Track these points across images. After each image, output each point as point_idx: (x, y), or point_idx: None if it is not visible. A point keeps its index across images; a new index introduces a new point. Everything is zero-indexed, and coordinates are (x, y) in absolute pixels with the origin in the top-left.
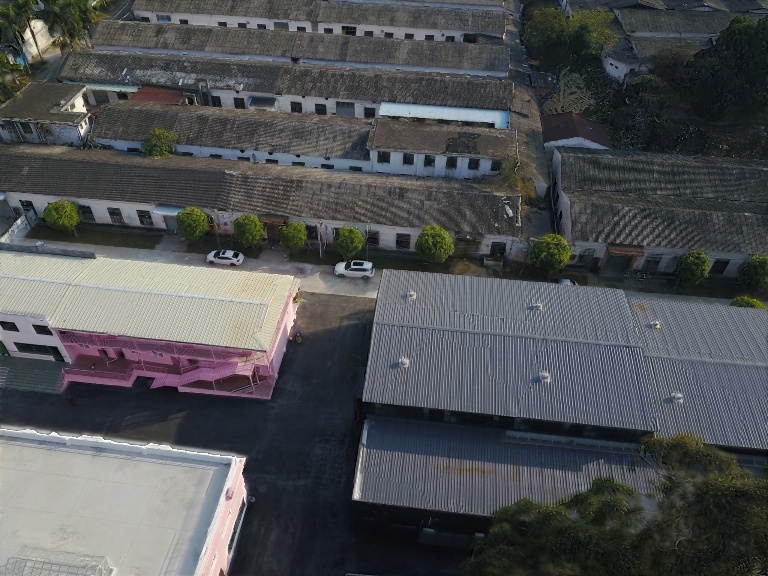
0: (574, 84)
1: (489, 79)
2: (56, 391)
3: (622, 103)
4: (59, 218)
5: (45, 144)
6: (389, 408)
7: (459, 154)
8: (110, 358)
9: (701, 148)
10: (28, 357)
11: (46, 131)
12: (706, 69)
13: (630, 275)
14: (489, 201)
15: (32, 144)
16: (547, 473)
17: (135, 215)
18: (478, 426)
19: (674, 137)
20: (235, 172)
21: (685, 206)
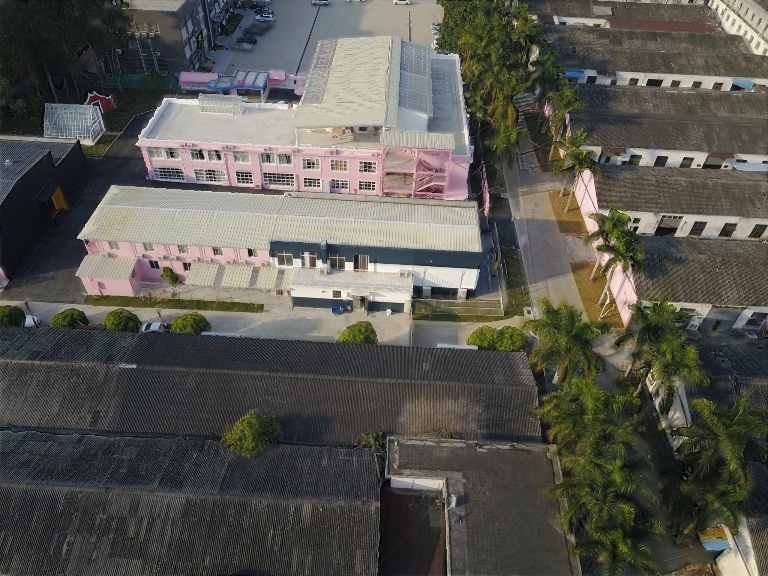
0: None
1: None
2: None
3: None
4: None
5: None
6: None
7: None
8: None
9: None
10: None
11: None
12: None
13: None
14: None
15: None
16: None
17: None
18: None
19: None
20: (122, 366)
21: None
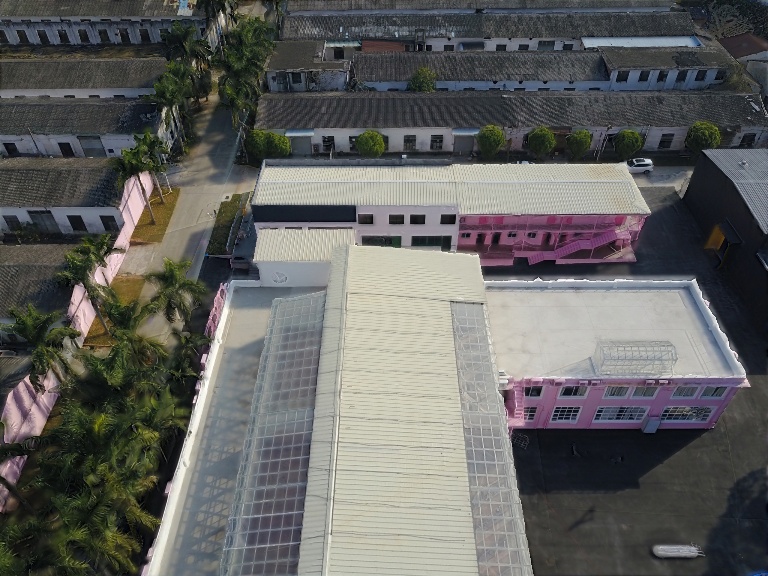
0: (729, 13)
1: None
2: None
3: None
4: (373, 145)
5: (316, 91)
6: None
7: (691, 67)
8: (486, 245)
9: None
10: None
11: (322, 78)
12: None
13: None
14: (735, 100)
15: (304, 92)
16: None
17: (428, 140)
18: None
19: None
20: (511, 96)
21: None
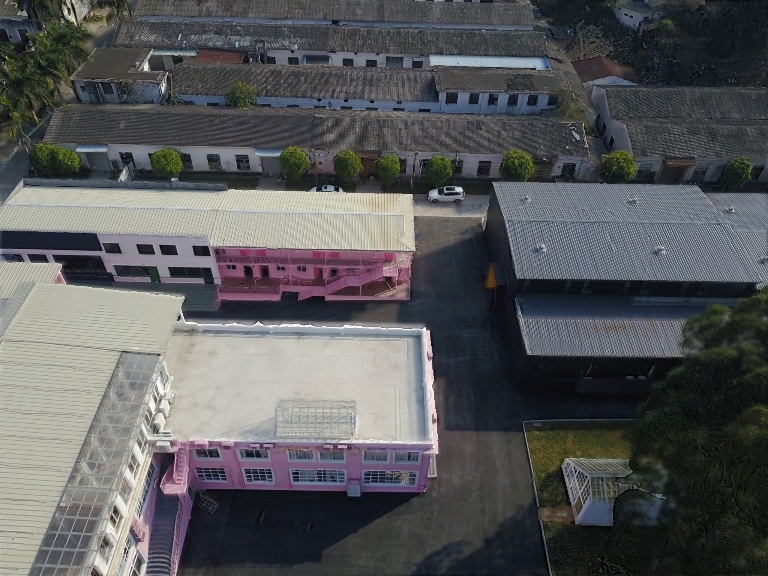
0: (592, 35)
1: (521, 31)
2: (213, 309)
3: (640, 47)
4: (167, 164)
5: (127, 103)
6: (536, 285)
7: (520, 91)
8: (255, 277)
9: (713, 82)
10: (178, 282)
11: (131, 89)
12: (717, 11)
13: (684, 184)
14: (557, 128)
15: (115, 103)
16: (676, 324)
17: (233, 160)
18: (610, 295)
19: (689, 74)
20: (324, 115)
21: (721, 124)
